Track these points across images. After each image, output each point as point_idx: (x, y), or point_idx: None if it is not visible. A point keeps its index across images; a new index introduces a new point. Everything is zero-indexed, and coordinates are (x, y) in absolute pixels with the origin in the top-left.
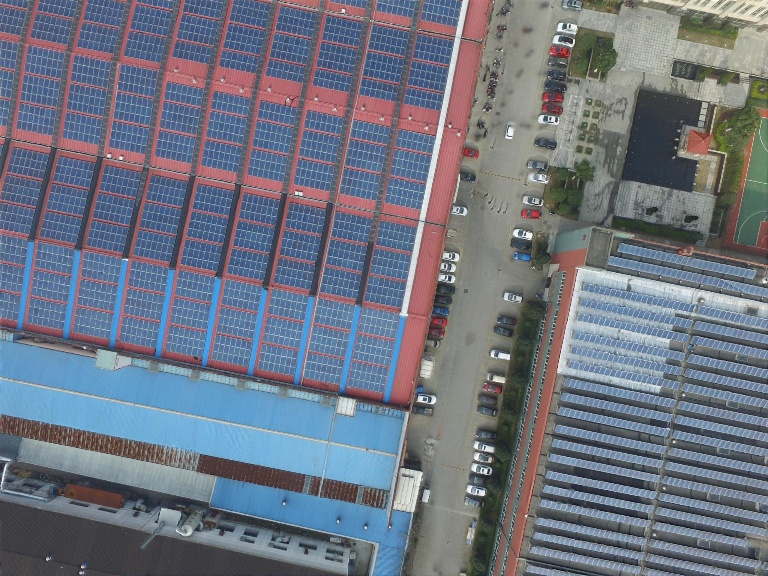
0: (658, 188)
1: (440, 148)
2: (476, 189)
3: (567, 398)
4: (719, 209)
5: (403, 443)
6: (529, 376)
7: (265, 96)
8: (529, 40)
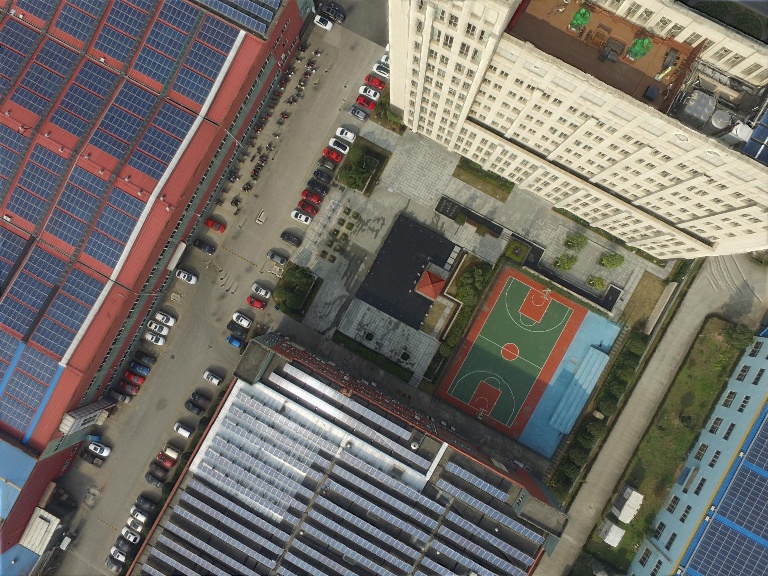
0: (387, 316)
1: (148, 216)
2: (213, 262)
3: (186, 498)
4: (439, 356)
5: (22, 488)
6: None
7: (2, 118)
8: (308, 135)
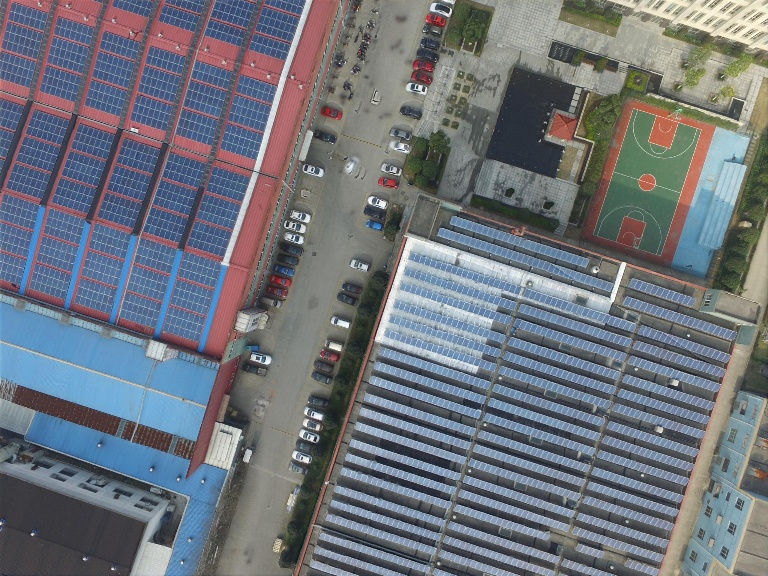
0: (521, 170)
1: (281, 99)
2: (336, 151)
3: (380, 367)
4: (580, 198)
5: (210, 394)
6: (366, 347)
7: (109, 27)
8: (406, 5)
